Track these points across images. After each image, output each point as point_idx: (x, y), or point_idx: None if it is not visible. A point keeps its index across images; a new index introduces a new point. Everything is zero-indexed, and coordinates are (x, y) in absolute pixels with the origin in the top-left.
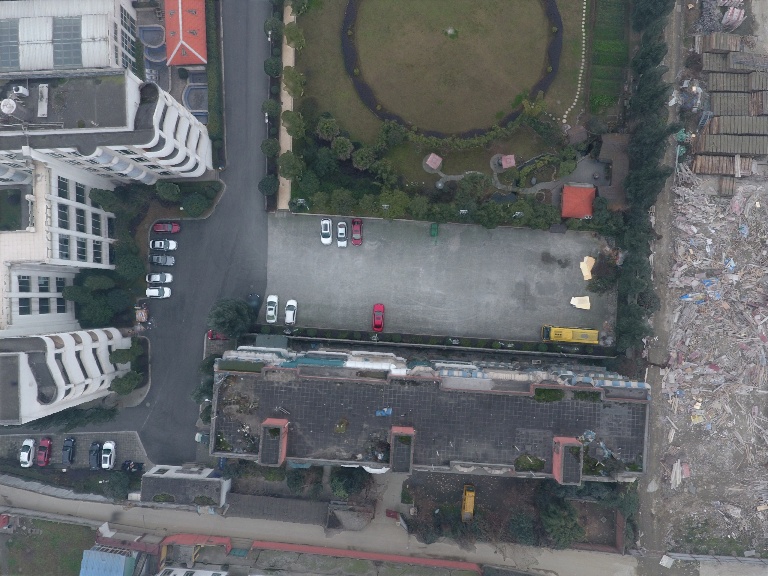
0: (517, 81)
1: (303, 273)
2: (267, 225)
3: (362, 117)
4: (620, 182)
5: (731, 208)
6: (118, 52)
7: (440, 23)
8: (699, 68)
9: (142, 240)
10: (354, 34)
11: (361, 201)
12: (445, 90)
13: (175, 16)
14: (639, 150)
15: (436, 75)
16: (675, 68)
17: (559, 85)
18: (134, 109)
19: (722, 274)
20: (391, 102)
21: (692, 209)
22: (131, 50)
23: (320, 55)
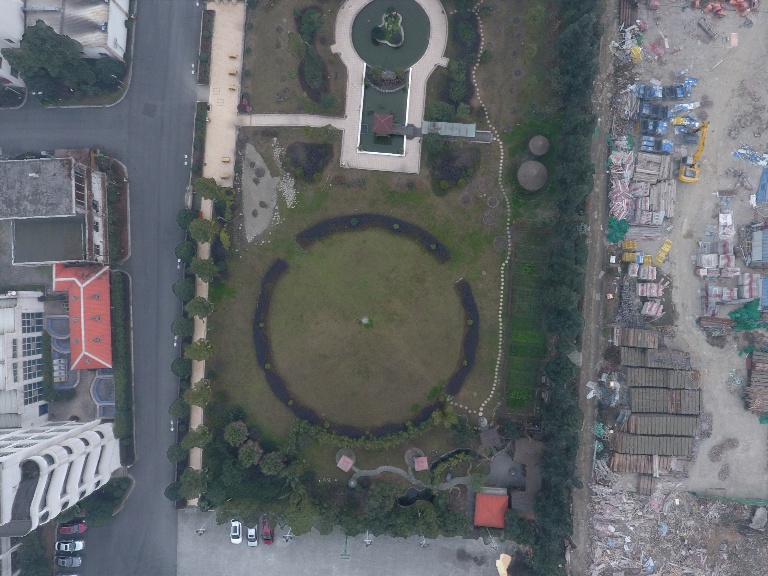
0: (433, 372)
1: (213, 571)
2: (177, 521)
3: (274, 409)
4: (533, 490)
5: (650, 505)
6: (17, 367)
7: (354, 312)
8: (617, 362)
9: (49, 538)
10: (266, 325)
11: (267, 517)
12: (359, 381)
13: (78, 324)
14: (548, 475)
15: (350, 366)
16: (593, 359)
17: (475, 376)
18: (12, 495)
19: (640, 575)
20: (304, 394)
21: (609, 508)
22: (36, 348)
23: (232, 345)
